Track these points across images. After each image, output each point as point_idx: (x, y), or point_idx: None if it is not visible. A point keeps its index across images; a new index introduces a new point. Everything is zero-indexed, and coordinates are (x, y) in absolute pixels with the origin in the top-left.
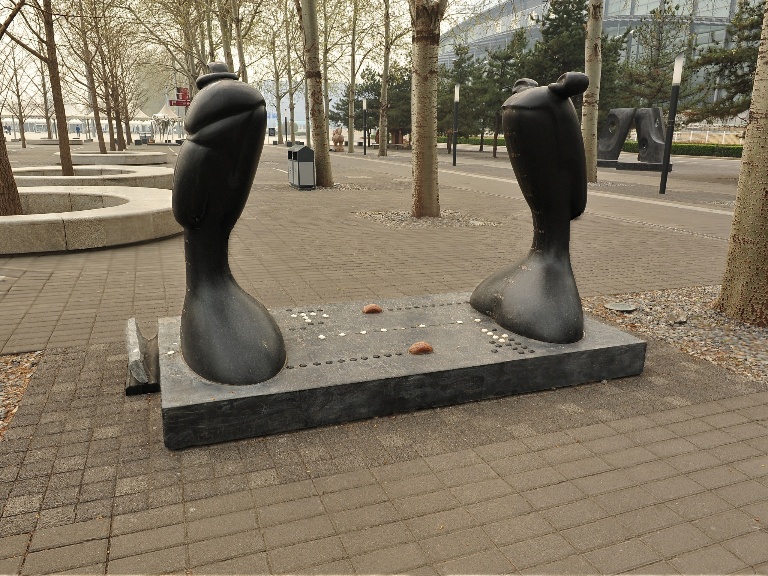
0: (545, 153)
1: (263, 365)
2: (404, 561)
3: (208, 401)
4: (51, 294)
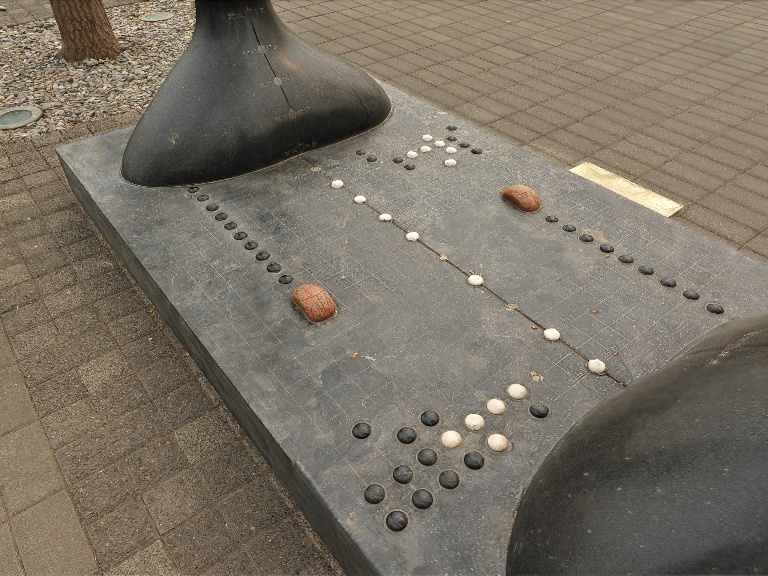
0: None
1: (146, 163)
2: None
3: (71, 166)
4: (473, 8)
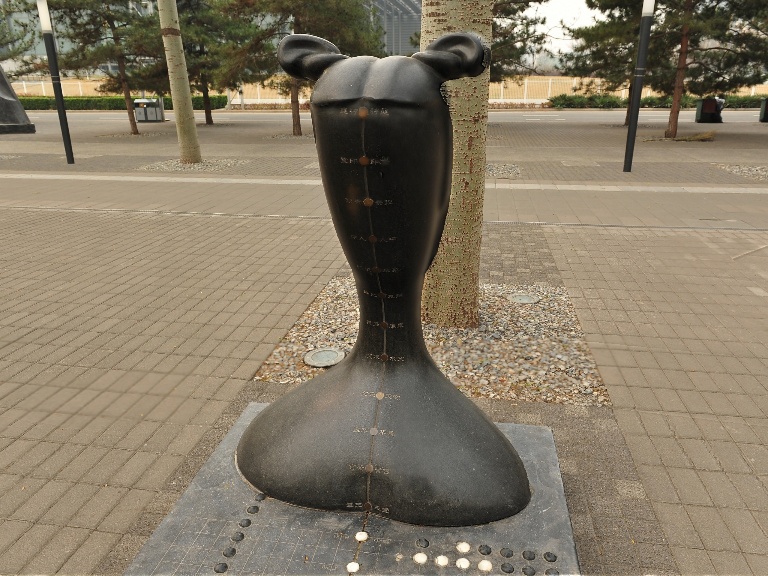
0: (433, 191)
1: None
2: None
3: None
4: None
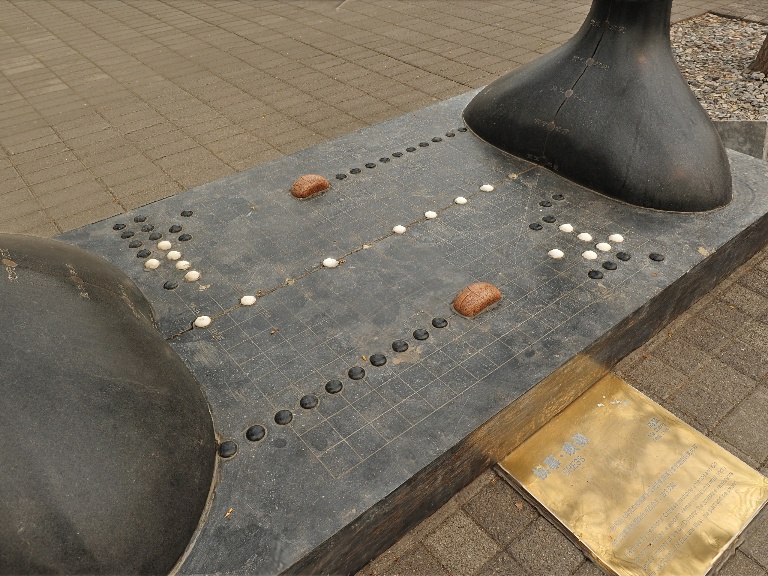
0: None
1: None
2: (284, 102)
3: None
4: None
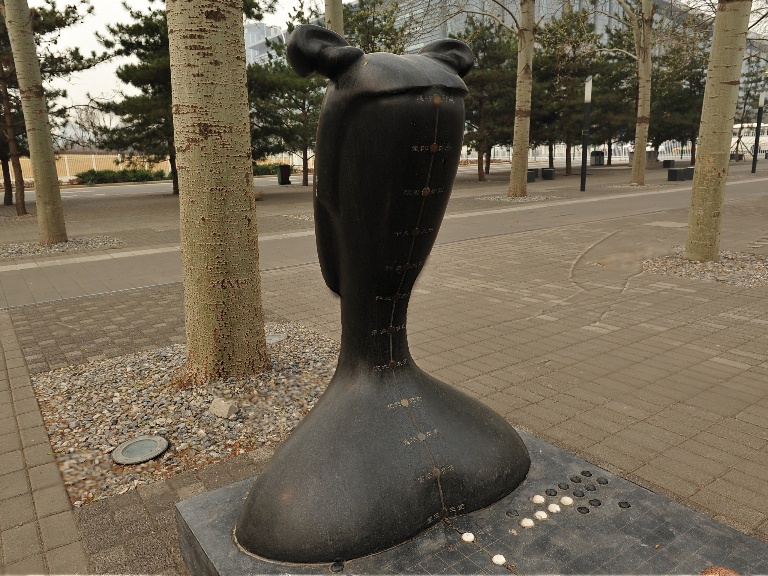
0: None
1: None
2: None
3: None
4: None
